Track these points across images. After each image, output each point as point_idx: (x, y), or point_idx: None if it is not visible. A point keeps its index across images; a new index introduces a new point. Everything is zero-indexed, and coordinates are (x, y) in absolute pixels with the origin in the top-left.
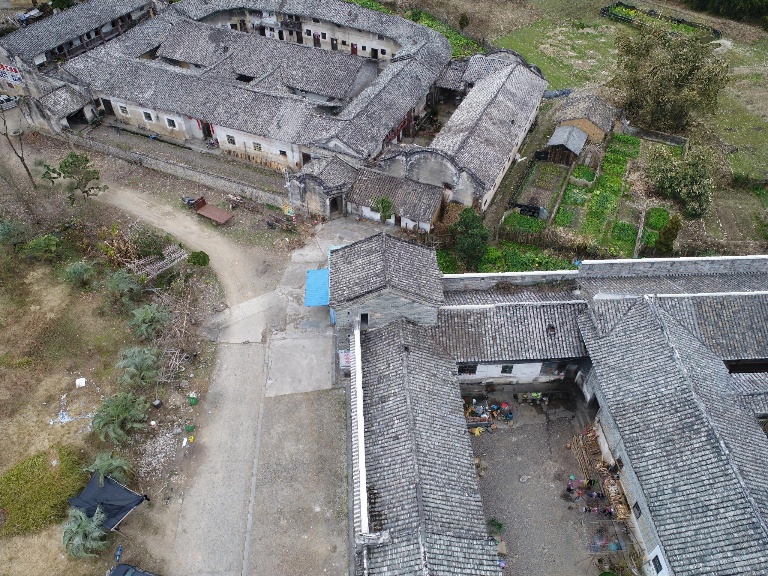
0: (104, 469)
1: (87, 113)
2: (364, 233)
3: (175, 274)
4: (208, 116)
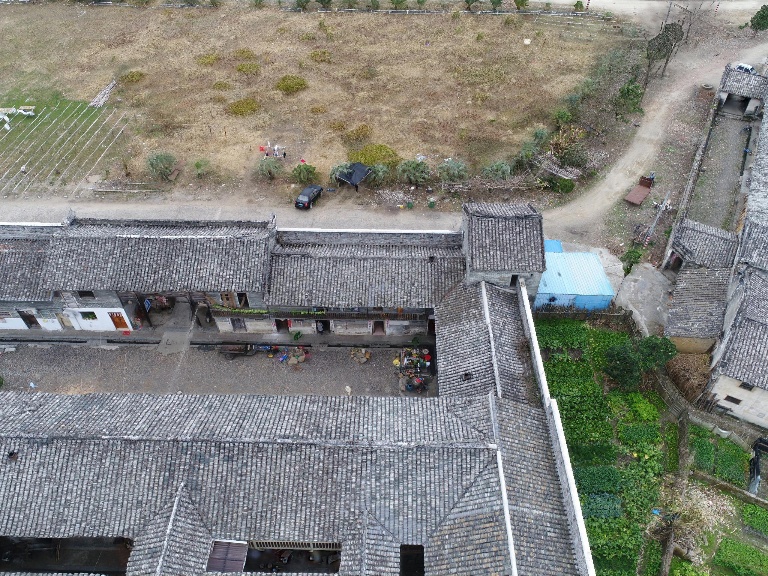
0: (375, 168)
1: (750, 106)
2: (650, 298)
3: (553, 182)
4: (763, 153)
